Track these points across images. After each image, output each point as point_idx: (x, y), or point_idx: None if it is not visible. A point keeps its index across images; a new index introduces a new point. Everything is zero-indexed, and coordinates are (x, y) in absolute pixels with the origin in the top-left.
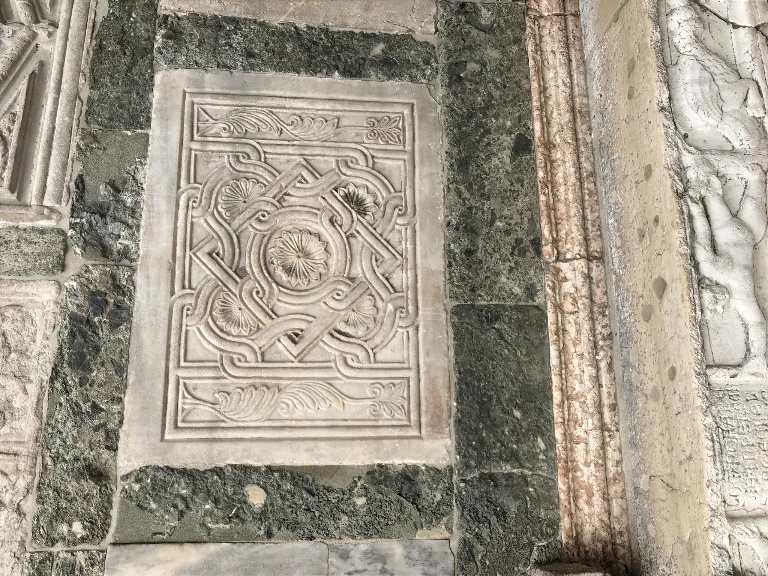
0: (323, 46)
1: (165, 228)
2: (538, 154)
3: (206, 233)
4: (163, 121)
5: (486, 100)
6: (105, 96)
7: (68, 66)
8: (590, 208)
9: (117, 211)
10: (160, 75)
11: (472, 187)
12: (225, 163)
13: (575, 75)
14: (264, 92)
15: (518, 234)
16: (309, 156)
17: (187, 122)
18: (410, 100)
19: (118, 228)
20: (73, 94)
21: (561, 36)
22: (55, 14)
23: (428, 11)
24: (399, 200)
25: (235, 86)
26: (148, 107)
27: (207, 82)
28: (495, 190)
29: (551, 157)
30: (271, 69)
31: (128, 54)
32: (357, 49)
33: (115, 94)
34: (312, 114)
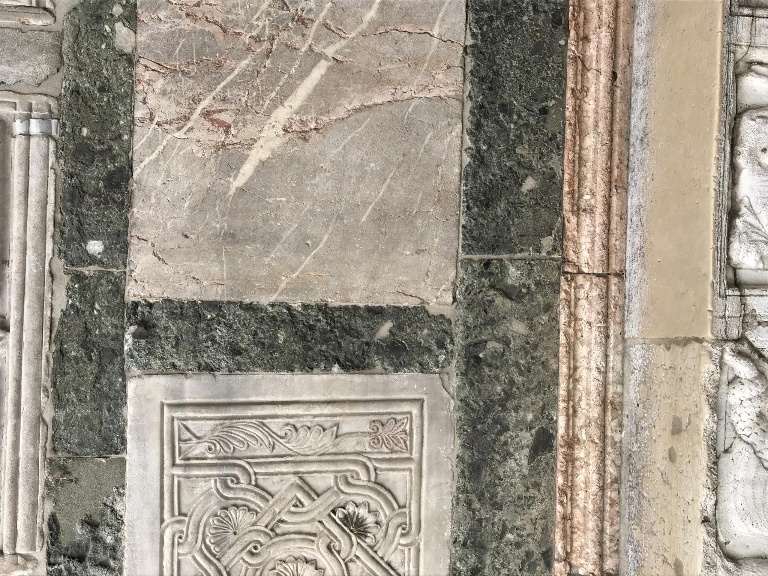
0: (321, 330)
1: (150, 569)
2: (560, 455)
3: (194, 570)
4: (140, 443)
5: (506, 389)
6: (72, 415)
7: (26, 381)
8: (611, 521)
9: (97, 551)
10: (133, 385)
11: (484, 495)
12: (212, 489)
13: (611, 357)
14: (253, 399)
15: (530, 548)
16: (305, 474)
17: (167, 443)
18: (420, 396)
19: (99, 572)
20: (36, 417)
21: (600, 307)
22: (4, 304)
23: (446, 275)
24: (403, 518)
25: (220, 393)
26: (122, 425)
27: (188, 391)
28: (509, 497)
29: (574, 455)
30: (261, 369)
31: (94, 359)
32: (360, 330)
33: (83, 412)
34: (308, 421)
